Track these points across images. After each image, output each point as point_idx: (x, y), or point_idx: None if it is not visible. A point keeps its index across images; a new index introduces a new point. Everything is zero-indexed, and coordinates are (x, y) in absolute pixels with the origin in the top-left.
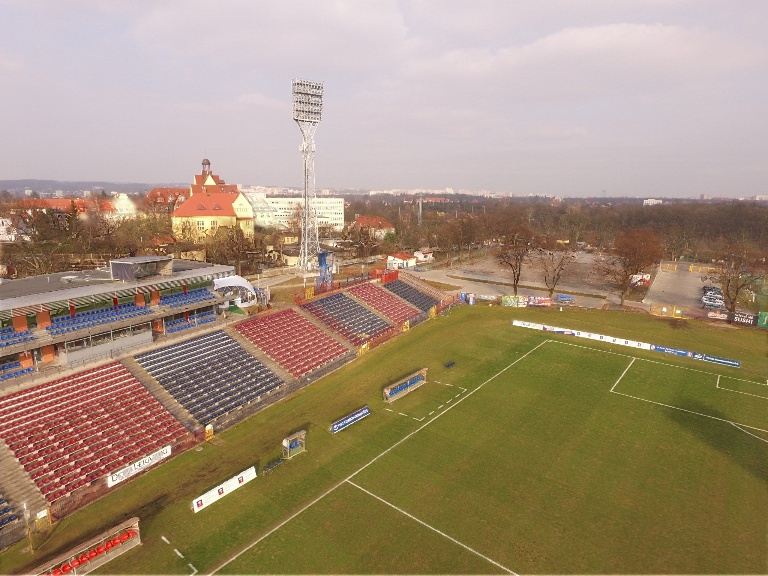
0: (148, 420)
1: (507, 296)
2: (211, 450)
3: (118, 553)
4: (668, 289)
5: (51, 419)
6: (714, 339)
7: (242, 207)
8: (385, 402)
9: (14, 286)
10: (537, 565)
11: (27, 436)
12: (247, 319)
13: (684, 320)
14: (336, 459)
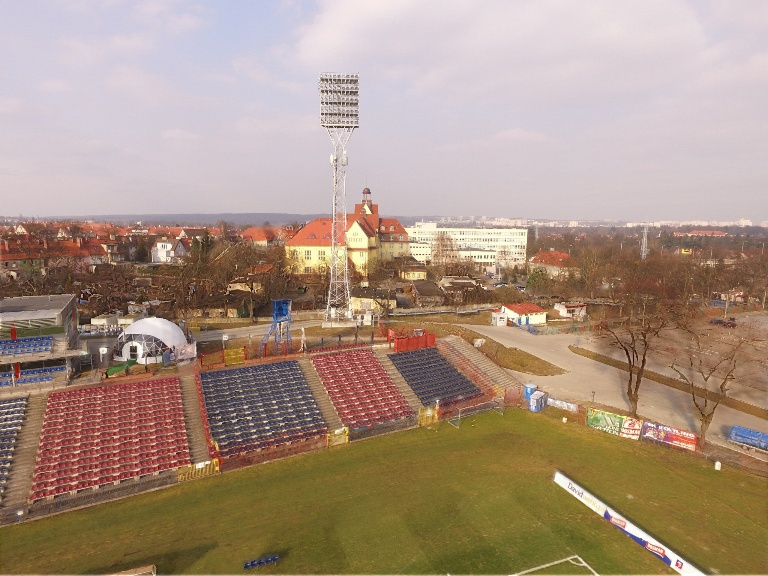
0: None
1: (598, 410)
2: None
3: None
4: None
5: None
6: None
7: (356, 237)
8: None
9: None
10: None
11: None
12: (92, 385)
13: None
14: None
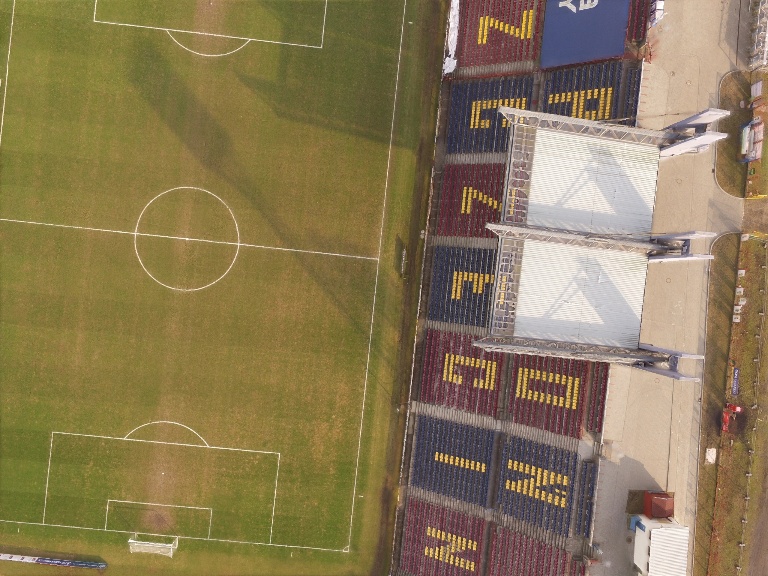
0: None
1: None
2: None
3: None
4: None
5: None
6: None
7: None
8: None
9: None
10: (90, 219)
11: None
12: None
13: None
14: None
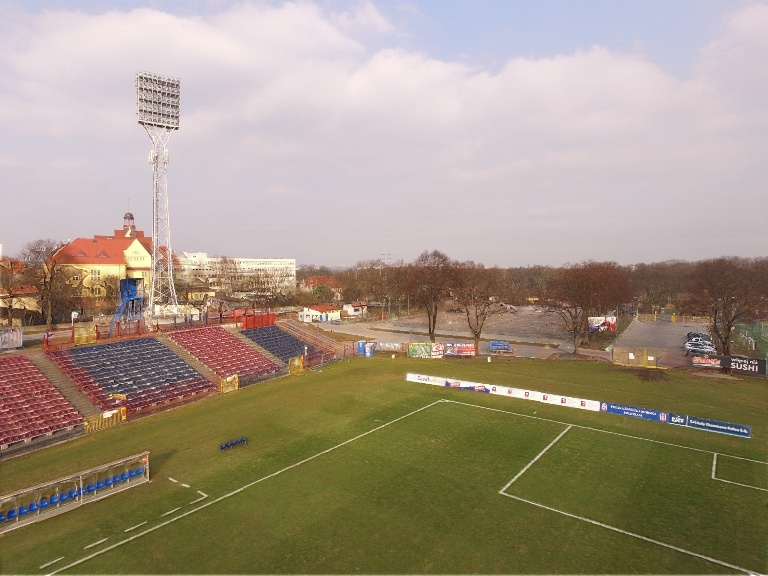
0: None
1: None
2: None
3: None
4: (643, 337)
5: None
6: (703, 393)
7: (137, 255)
8: None
9: None
10: None
11: None
12: None
13: (660, 370)
14: None
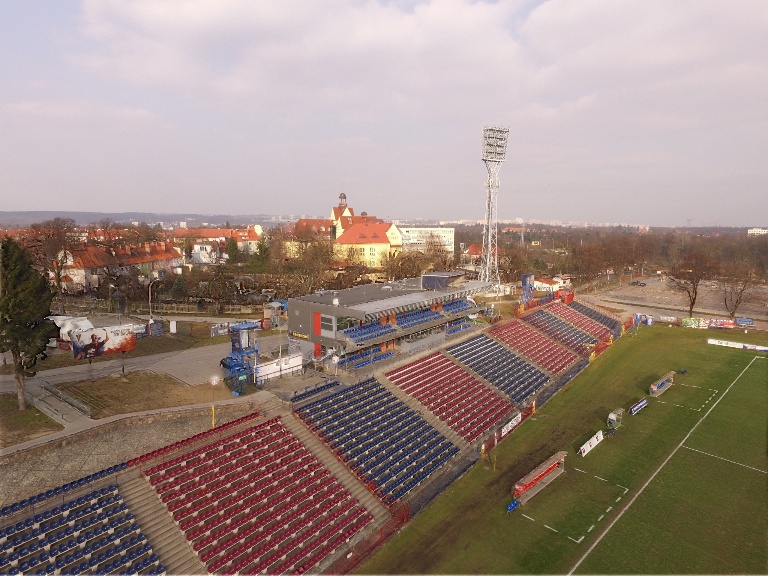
0: (485, 395)
1: (687, 318)
2: (544, 420)
3: (556, 475)
4: None
5: (431, 388)
6: None
7: (393, 236)
8: (652, 396)
9: (360, 292)
10: None
11: (427, 398)
12: (492, 327)
13: None
14: (656, 432)
